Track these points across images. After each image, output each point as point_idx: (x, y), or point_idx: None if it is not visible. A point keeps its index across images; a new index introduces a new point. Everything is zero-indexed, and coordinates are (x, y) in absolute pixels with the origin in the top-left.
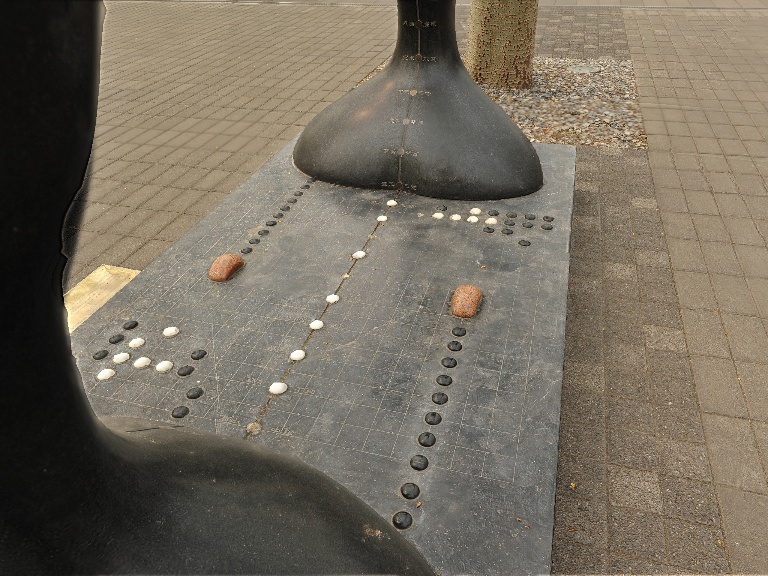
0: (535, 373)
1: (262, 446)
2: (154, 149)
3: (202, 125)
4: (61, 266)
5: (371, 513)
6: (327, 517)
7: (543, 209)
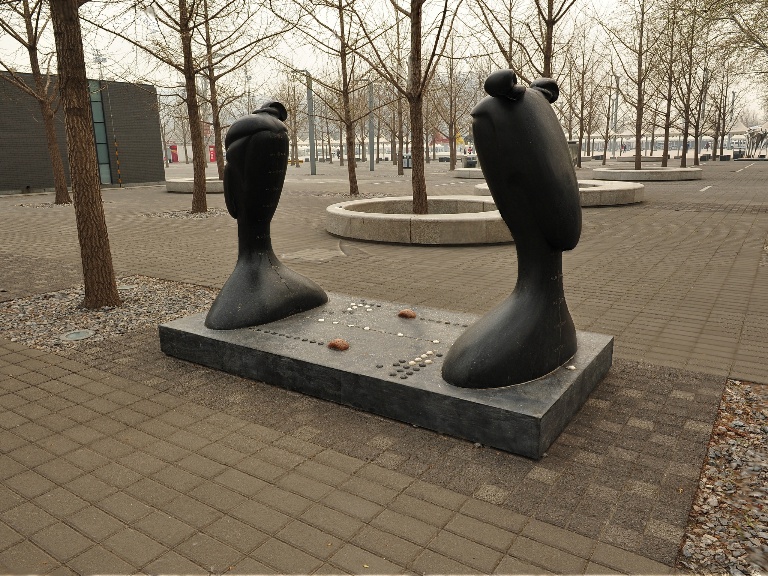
0: (283, 350)
1: (274, 294)
2: (653, 330)
3: (717, 342)
4: (257, 220)
5: (247, 310)
6: (243, 295)
7: (418, 379)
